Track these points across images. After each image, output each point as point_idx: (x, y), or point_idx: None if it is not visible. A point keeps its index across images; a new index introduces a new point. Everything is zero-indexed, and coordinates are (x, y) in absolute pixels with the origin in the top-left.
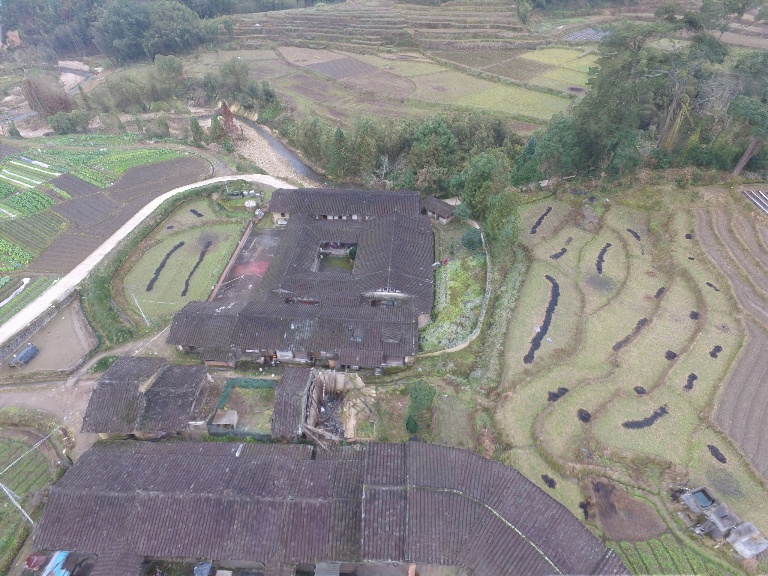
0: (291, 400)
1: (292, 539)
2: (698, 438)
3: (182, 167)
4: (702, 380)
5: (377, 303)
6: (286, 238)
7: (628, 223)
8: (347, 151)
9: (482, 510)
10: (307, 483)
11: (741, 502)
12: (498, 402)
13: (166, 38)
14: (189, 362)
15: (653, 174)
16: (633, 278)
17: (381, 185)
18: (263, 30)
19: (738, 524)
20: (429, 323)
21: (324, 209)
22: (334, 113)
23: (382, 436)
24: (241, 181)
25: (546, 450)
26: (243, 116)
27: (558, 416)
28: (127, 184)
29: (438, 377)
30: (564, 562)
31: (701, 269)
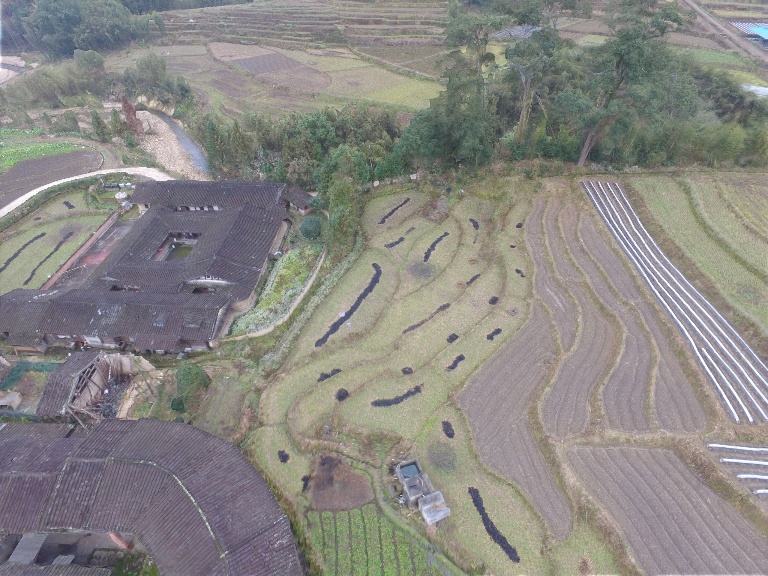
0: (63, 381)
1: (7, 511)
2: (436, 415)
3: (73, 160)
4: (468, 361)
5: (203, 290)
6: (135, 228)
7: (473, 213)
8: (223, 144)
9: (169, 480)
10: (43, 459)
11: (449, 474)
12: (270, 383)
13: (97, 33)
14: (2, 348)
15: (505, 165)
16: (454, 265)
17: (257, 177)
18: (197, 26)
19: (429, 493)
20: (249, 310)
21: (184, 200)
22: (242, 108)
23: (153, 416)
24: (122, 174)
25: (290, 427)
26: (161, 111)
27: (317, 395)
28: (12, 177)
29: (230, 360)
30: (225, 527)
31: (517, 256)
